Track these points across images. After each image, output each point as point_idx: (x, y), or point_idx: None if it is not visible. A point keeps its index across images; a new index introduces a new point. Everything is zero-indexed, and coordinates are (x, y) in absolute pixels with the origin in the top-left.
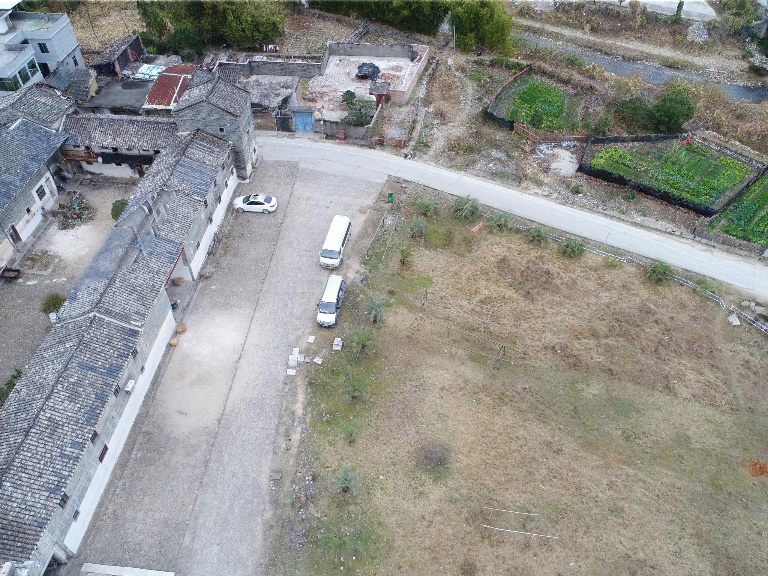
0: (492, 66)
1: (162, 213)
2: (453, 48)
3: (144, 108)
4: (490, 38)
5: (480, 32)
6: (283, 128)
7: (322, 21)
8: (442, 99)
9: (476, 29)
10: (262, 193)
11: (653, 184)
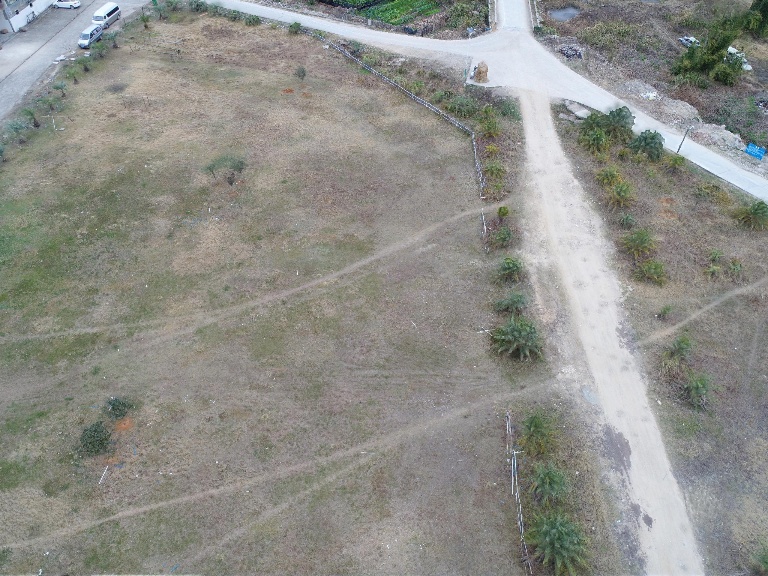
0: None
1: (3, 3)
2: None
3: None
4: None
5: None
6: None
7: None
8: None
9: None
10: (75, 1)
11: None
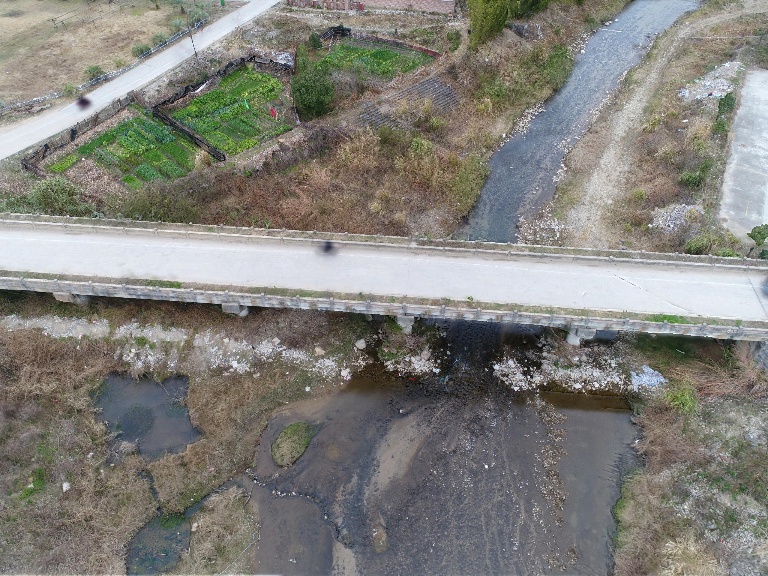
0: None
1: None
2: None
3: None
4: None
5: None
6: None
7: None
8: None
9: None
10: None
11: (213, 93)
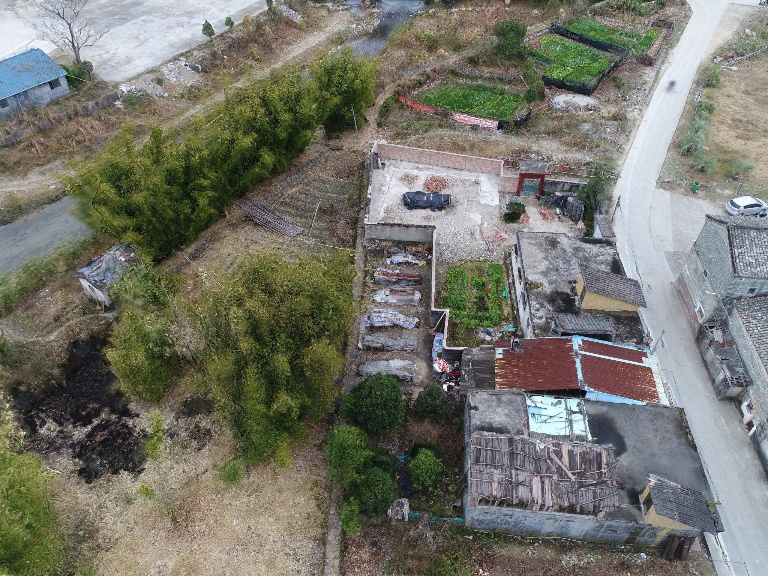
0: None
1: None
2: (337, 138)
3: (671, 403)
4: (369, 95)
5: None
6: None
7: (198, 262)
8: (479, 151)
9: None
10: None
11: (596, 68)
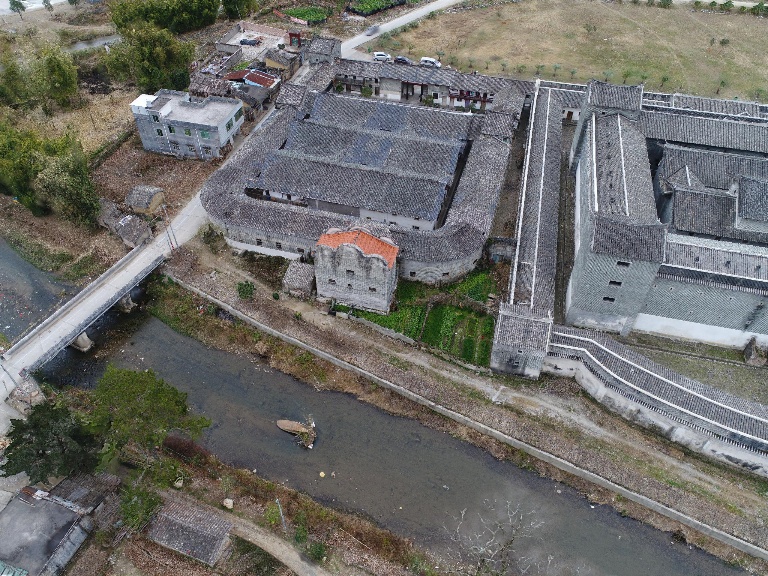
0: (260, 17)
1: None
2: (233, 22)
3: None
4: (251, 4)
5: None
6: (300, 65)
7: None
8: None
9: None
10: None
11: (382, 7)
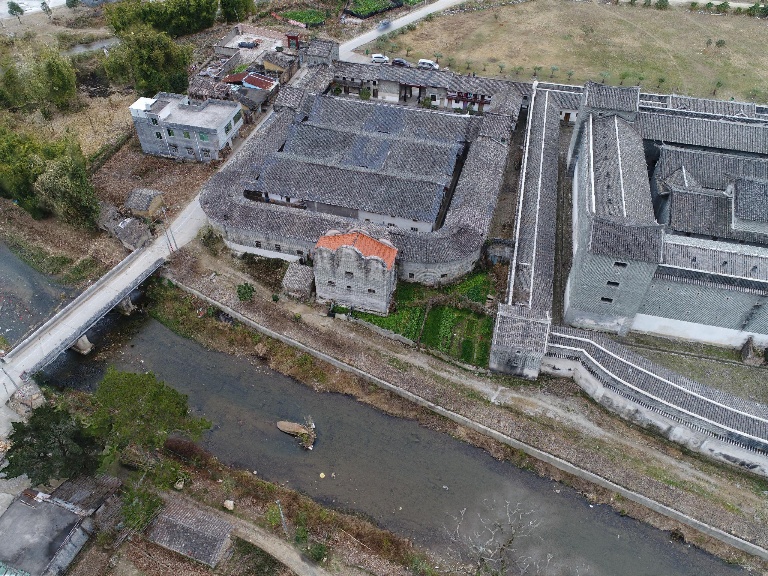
0: (258, 20)
1: None
2: (231, 24)
3: None
4: None
5: (244, 6)
6: (298, 68)
7: None
8: None
9: (241, 6)
10: None
11: (379, 9)
